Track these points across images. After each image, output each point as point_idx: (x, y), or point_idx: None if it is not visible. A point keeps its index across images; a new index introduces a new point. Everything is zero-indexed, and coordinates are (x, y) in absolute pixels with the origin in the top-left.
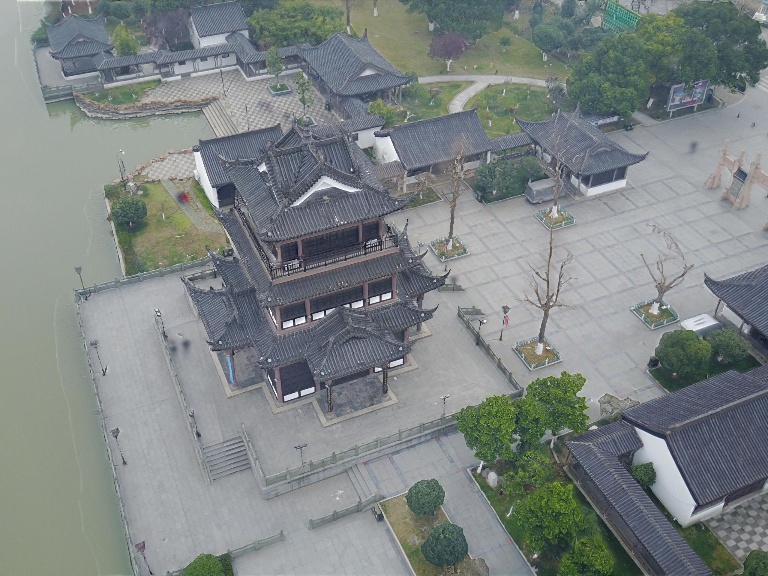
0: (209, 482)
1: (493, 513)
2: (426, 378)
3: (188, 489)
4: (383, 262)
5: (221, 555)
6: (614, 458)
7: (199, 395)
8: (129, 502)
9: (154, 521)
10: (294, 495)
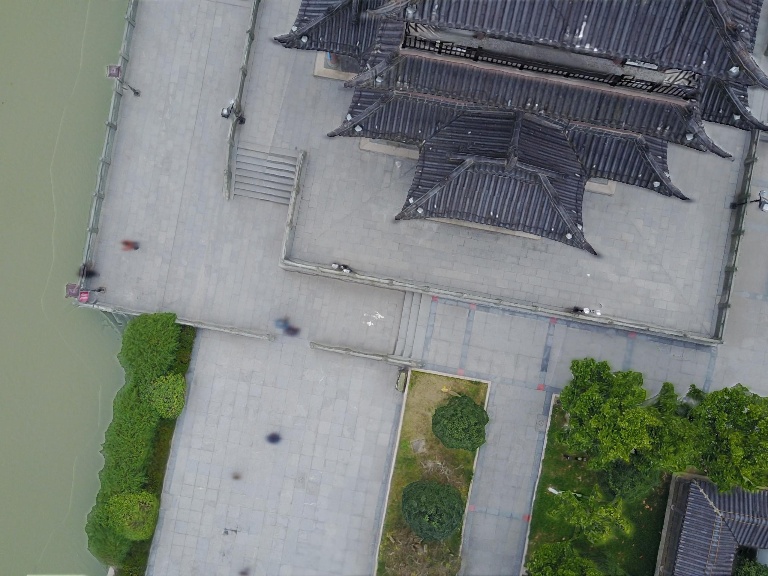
0: (226, 197)
1: (536, 473)
2: (609, 220)
3: (197, 188)
4: (642, 101)
5: (185, 324)
6: (732, 546)
7: (277, 42)
8: (118, 162)
9: (136, 212)
10: (321, 283)
